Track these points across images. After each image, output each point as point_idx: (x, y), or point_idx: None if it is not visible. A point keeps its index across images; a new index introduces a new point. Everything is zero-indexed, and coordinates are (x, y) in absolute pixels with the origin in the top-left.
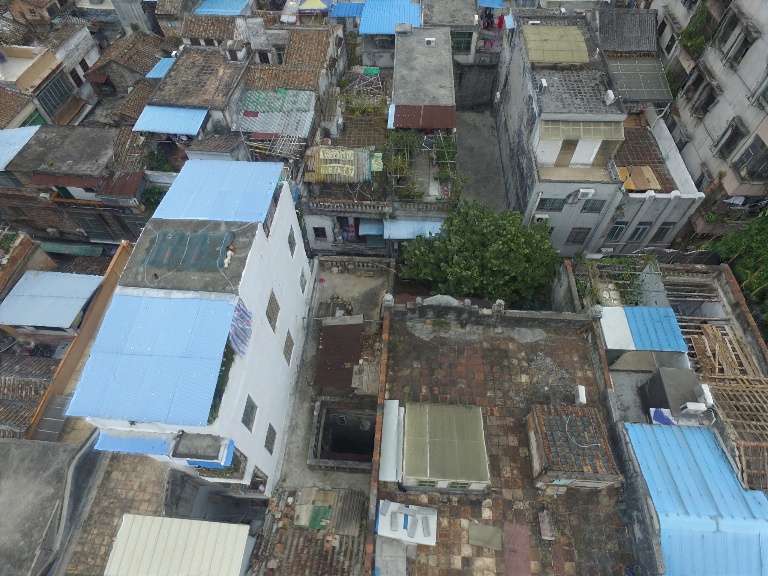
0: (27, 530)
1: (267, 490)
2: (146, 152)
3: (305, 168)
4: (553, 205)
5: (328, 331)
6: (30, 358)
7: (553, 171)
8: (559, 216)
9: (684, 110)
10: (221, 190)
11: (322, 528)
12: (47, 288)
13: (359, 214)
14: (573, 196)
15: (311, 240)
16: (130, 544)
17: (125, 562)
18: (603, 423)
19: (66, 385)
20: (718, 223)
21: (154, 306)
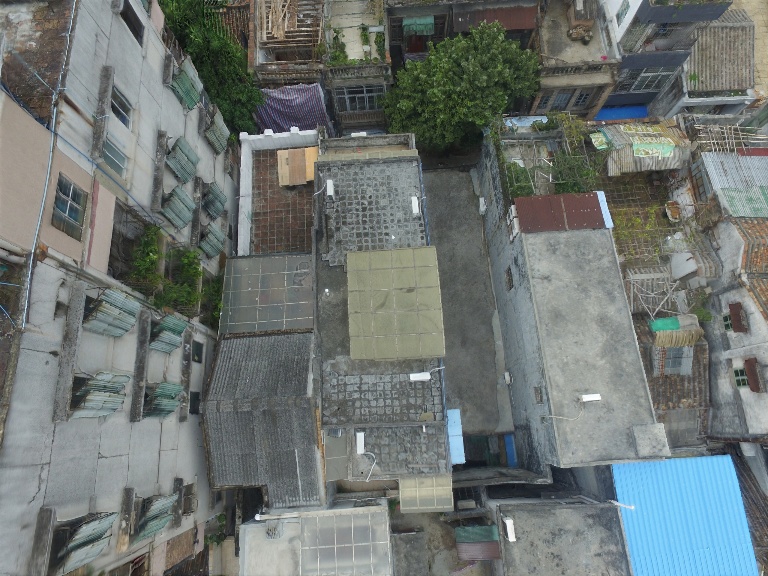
0: None
1: None
2: None
3: None
4: None
5: None
6: None
7: None
8: None
9: None
10: None
11: None
12: None
13: None
14: None
15: None
16: None
17: None
18: None
19: None
20: None
21: None
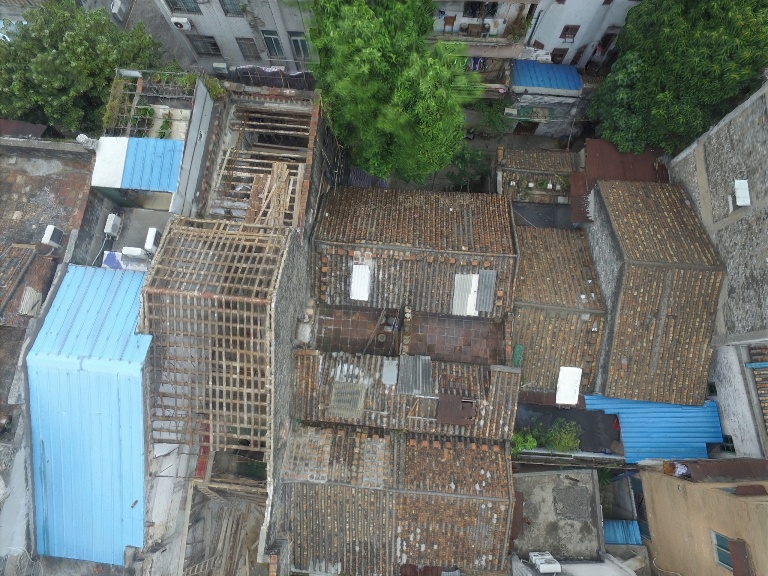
0: None
1: None
2: None
3: None
4: (186, 5)
5: None
6: None
7: None
8: (206, 21)
9: None
10: None
11: None
12: None
13: None
14: None
15: None
16: None
17: None
18: None
19: None
20: None
21: None
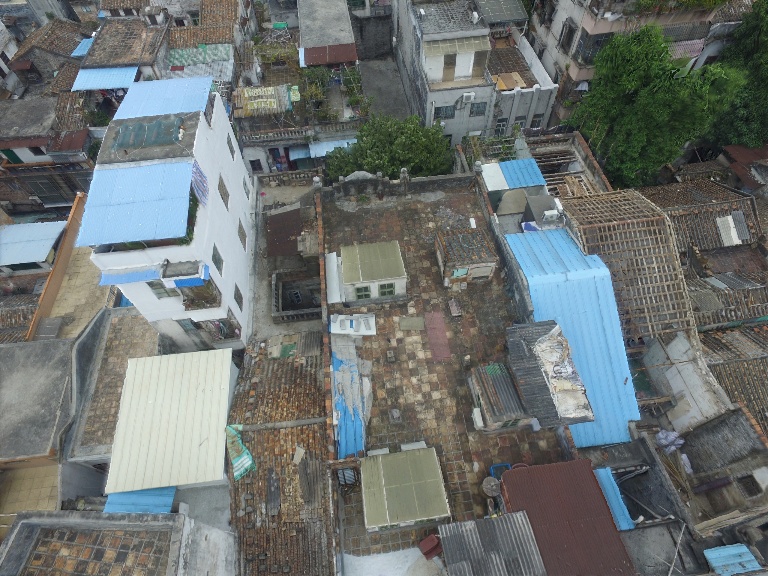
0: (45, 402)
1: (242, 337)
2: (87, 111)
3: (233, 106)
4: (446, 113)
5: (273, 219)
6: (12, 296)
7: (442, 85)
8: (453, 123)
9: (538, 25)
10: (165, 97)
11: (291, 355)
12: (16, 236)
13: (287, 141)
14: (460, 102)
15: (249, 174)
16: (138, 377)
17: (136, 389)
18: (491, 242)
19: (50, 311)
20: (573, 108)
21: (129, 173)
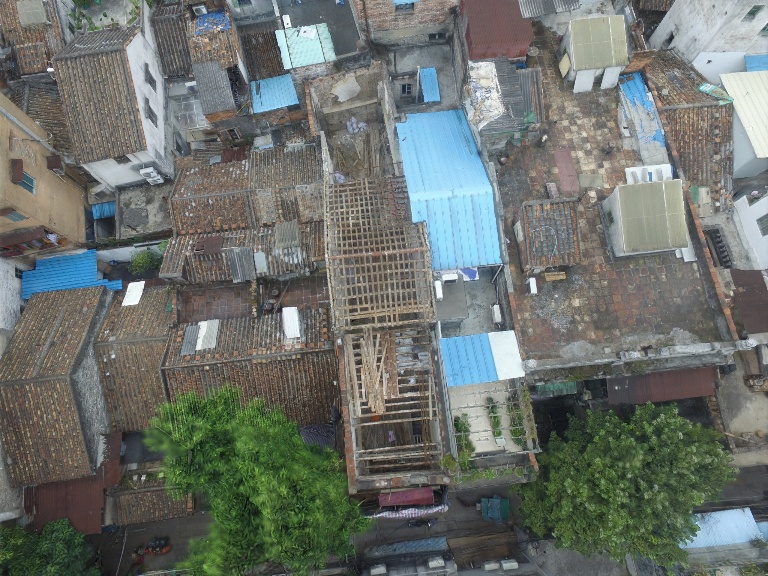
0: None
1: (744, 200)
2: None
3: None
4: None
5: None
6: None
7: None
8: None
9: None
10: None
11: None
12: None
13: None
14: None
15: None
16: None
17: None
18: None
19: None
20: None
21: None
